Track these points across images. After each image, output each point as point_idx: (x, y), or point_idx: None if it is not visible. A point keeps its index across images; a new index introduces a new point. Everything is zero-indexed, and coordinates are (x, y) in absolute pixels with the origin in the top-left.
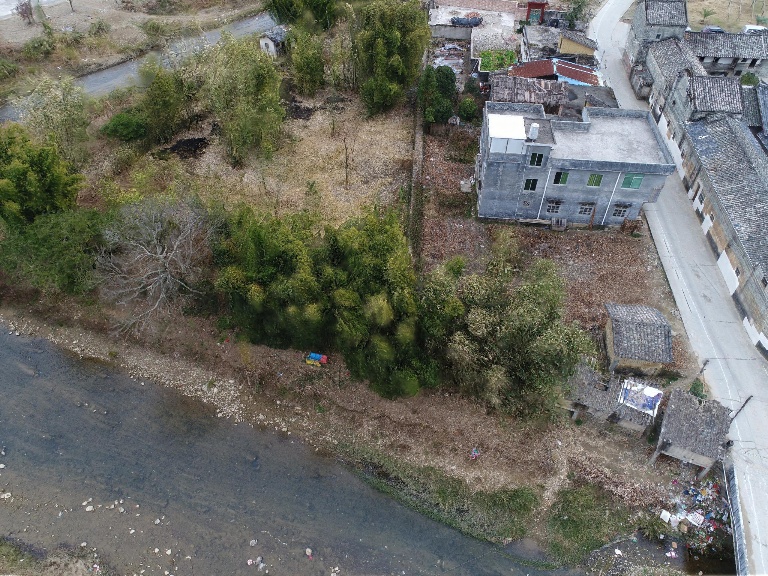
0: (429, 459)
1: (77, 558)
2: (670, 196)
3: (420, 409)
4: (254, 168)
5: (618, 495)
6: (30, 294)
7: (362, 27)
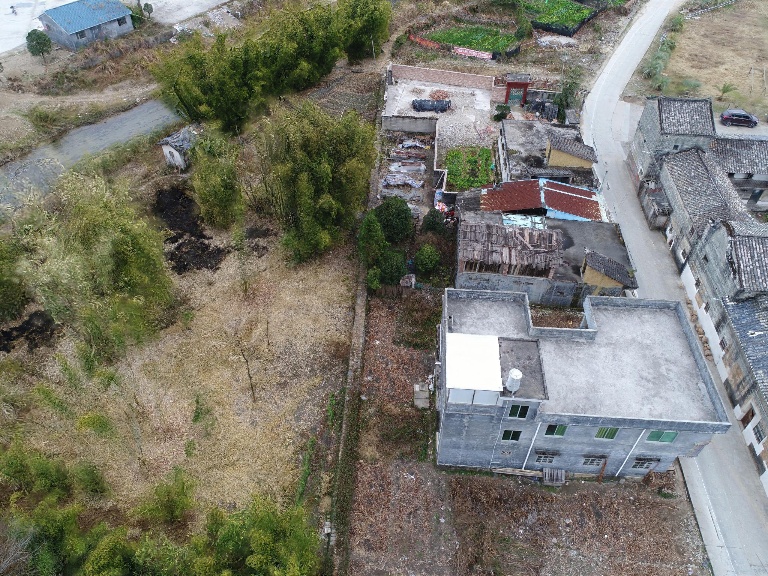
0: None
1: None
2: None
3: None
4: (130, 362)
5: None
6: None
7: (282, 152)
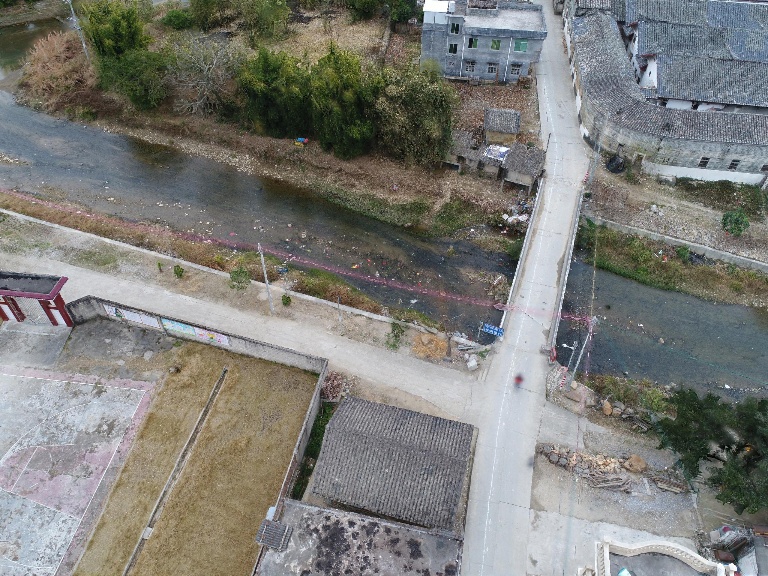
0: (367, 191)
1: (155, 223)
2: (557, 67)
3: (364, 166)
4: None
5: (477, 204)
6: (116, 111)
7: None
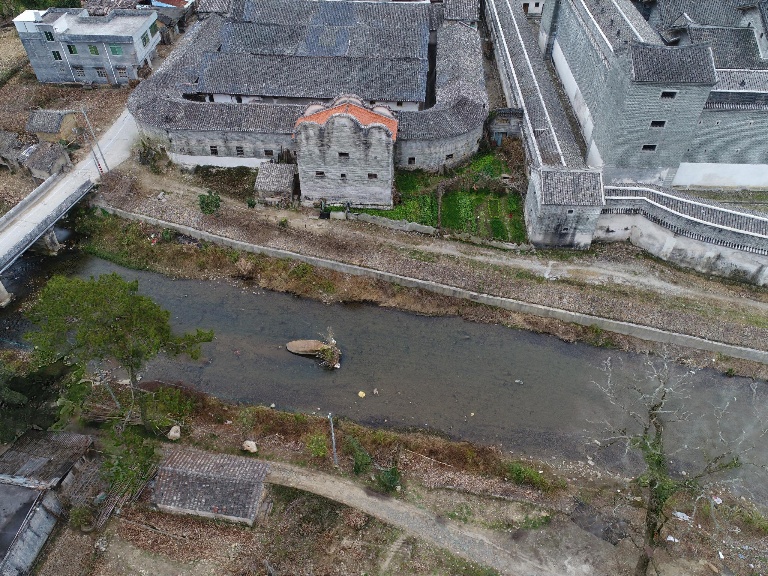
0: None
1: None
2: None
3: None
4: None
5: (8, 201)
6: None
7: None
